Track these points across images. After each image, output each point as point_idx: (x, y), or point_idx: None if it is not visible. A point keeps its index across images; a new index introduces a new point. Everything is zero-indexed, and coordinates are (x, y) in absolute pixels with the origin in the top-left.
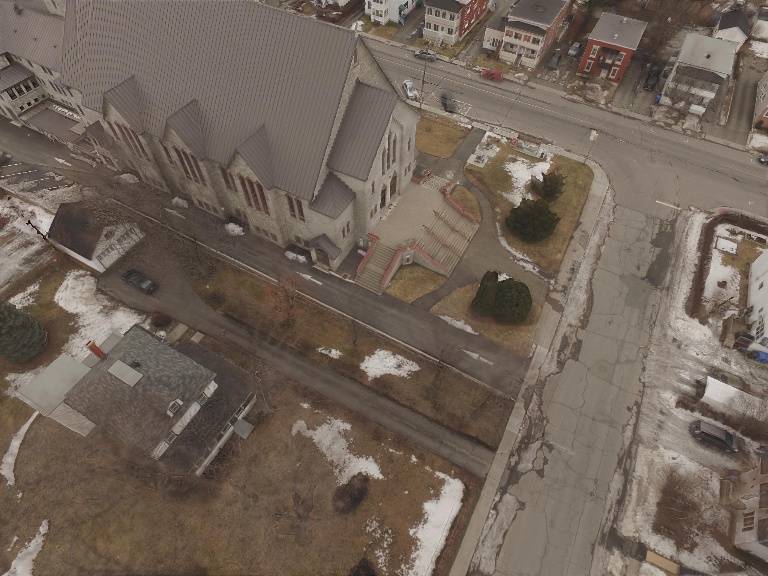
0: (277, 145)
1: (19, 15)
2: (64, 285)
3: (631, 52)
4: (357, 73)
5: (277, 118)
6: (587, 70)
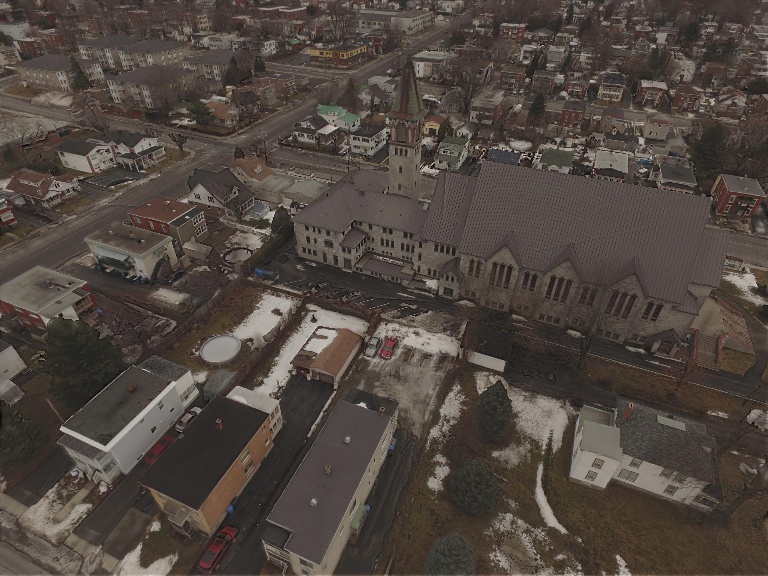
0: (649, 268)
1: (362, 195)
2: (480, 383)
3: (762, 198)
4: None
5: (648, 251)
6: (726, 211)
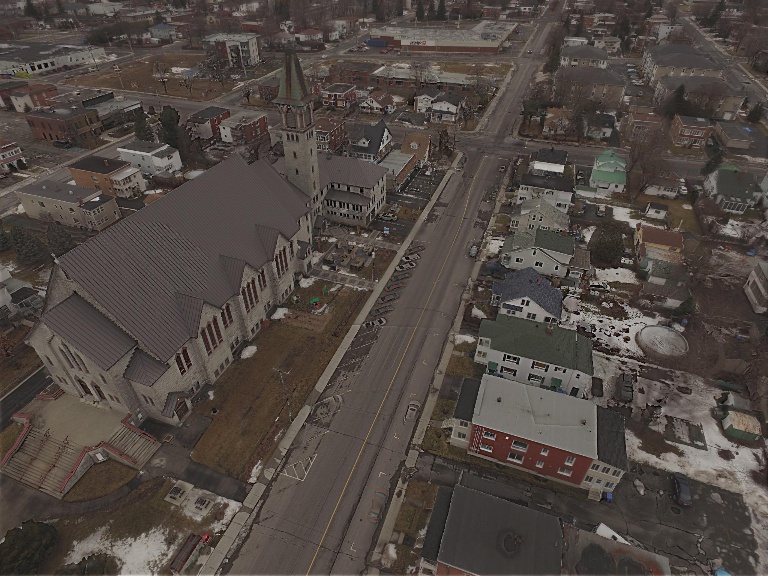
0: None
1: None
2: None
3: None
4: (74, 287)
5: None
6: None
